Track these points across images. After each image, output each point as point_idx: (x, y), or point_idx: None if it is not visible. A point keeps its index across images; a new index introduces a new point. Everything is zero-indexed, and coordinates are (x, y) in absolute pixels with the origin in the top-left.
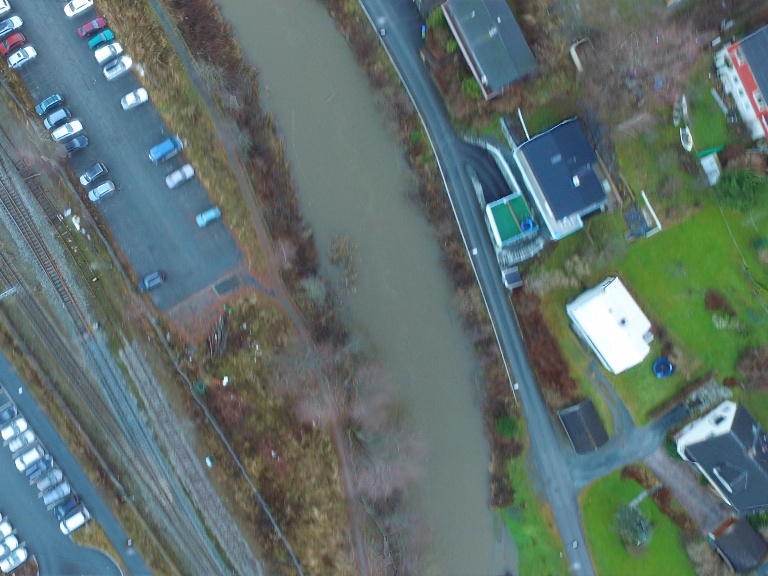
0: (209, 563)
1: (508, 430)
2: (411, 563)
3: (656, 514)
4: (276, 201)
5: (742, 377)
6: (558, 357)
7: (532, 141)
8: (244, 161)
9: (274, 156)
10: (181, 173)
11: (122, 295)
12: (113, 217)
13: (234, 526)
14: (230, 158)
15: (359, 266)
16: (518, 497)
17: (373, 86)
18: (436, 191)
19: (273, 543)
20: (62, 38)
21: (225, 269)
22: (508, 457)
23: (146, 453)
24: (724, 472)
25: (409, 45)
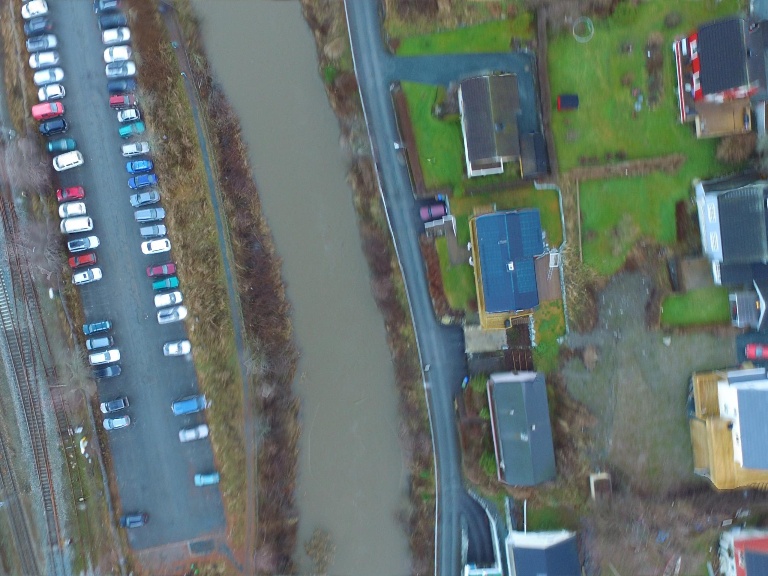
0: None
1: None
2: None
3: None
4: (275, 483)
5: None
6: None
7: (525, 549)
8: (258, 440)
9: (288, 439)
10: (196, 432)
11: (102, 521)
12: (119, 447)
13: None
14: (246, 430)
15: (330, 567)
16: None
17: (402, 405)
18: (426, 527)
19: None
20: (131, 268)
21: (205, 531)
22: None
23: None
24: None
25: (447, 387)
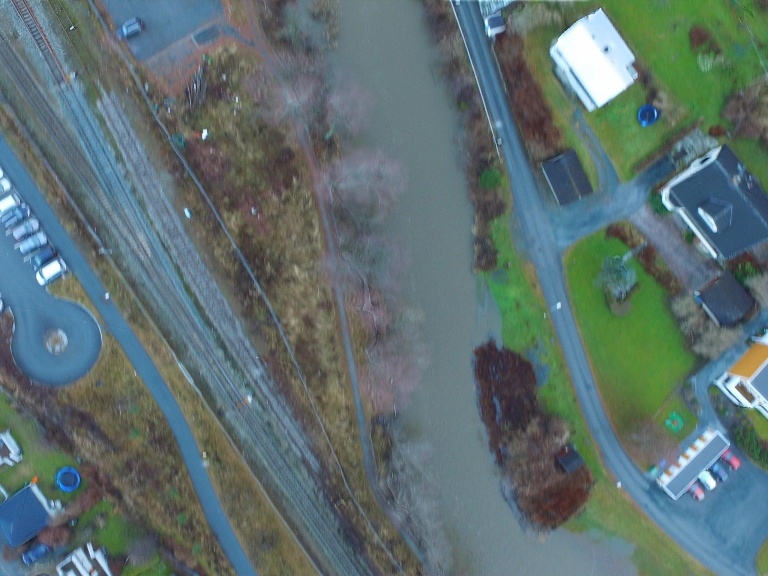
0: (188, 320)
1: (491, 182)
2: (393, 323)
3: (641, 275)
4: None
5: (728, 123)
6: (541, 103)
7: None
8: None
9: None
10: None
11: (100, 44)
12: None
13: (213, 283)
14: None
15: (341, 20)
16: (501, 258)
17: None
18: None
19: (253, 301)
20: None
21: (204, 19)
22: (491, 217)
23: (124, 206)
24: (709, 207)
25: None
